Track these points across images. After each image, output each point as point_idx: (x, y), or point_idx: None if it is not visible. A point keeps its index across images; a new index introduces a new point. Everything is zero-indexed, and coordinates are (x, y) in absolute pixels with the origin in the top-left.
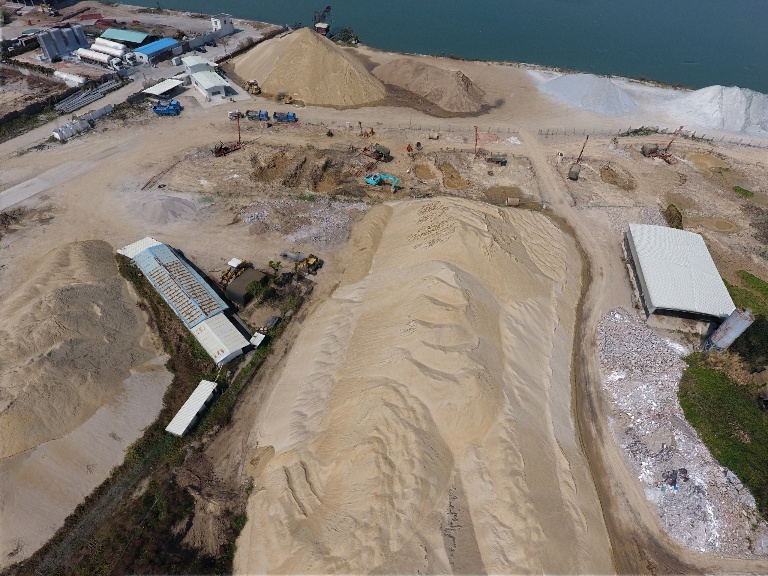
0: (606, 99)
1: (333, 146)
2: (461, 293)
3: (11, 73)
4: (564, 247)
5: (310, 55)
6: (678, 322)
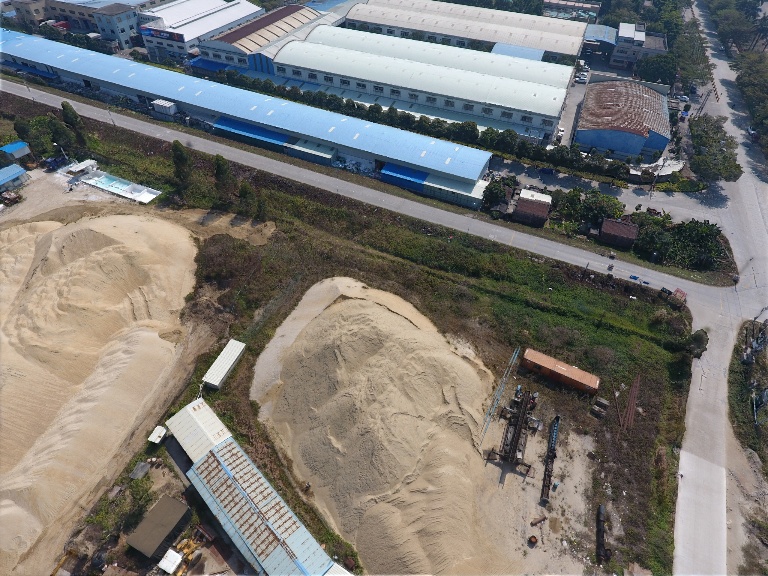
0: None
1: None
2: None
3: None
4: None
5: None
6: None
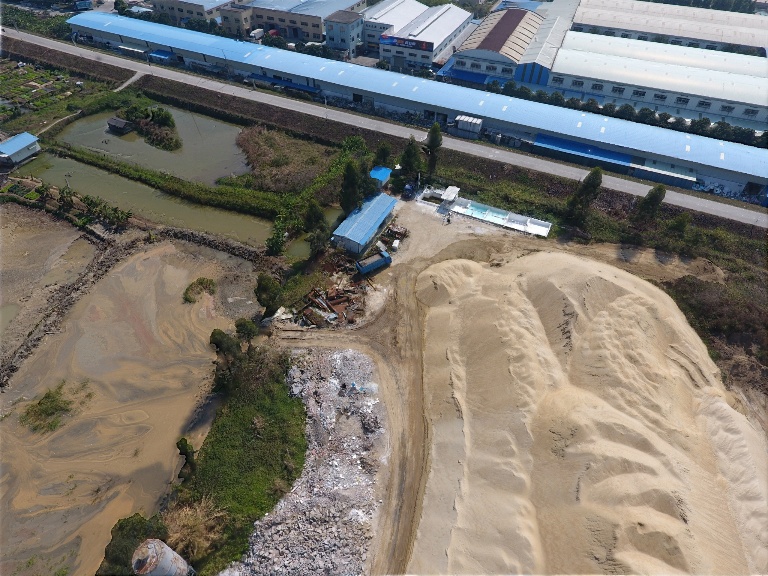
0: None
1: None
2: (634, 569)
3: None
4: None
5: None
6: None
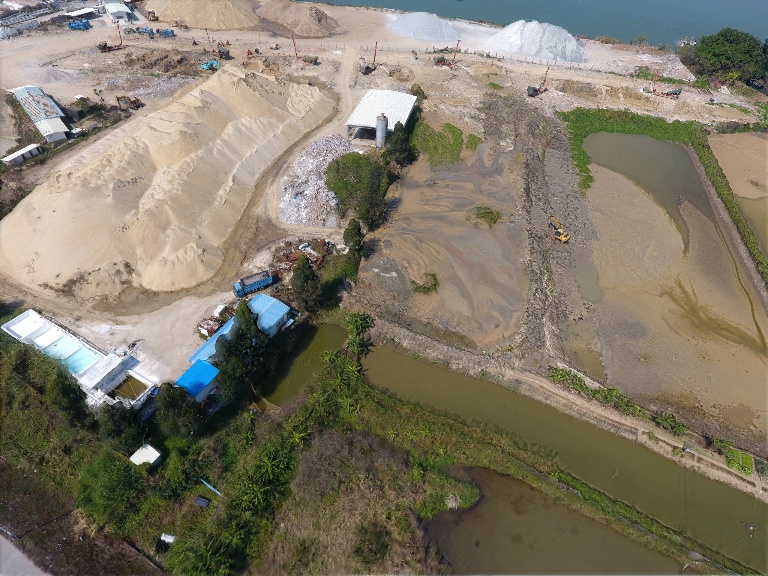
0: (431, 30)
1: (193, 50)
2: (199, 100)
3: None
4: (316, 101)
5: None
6: (373, 142)
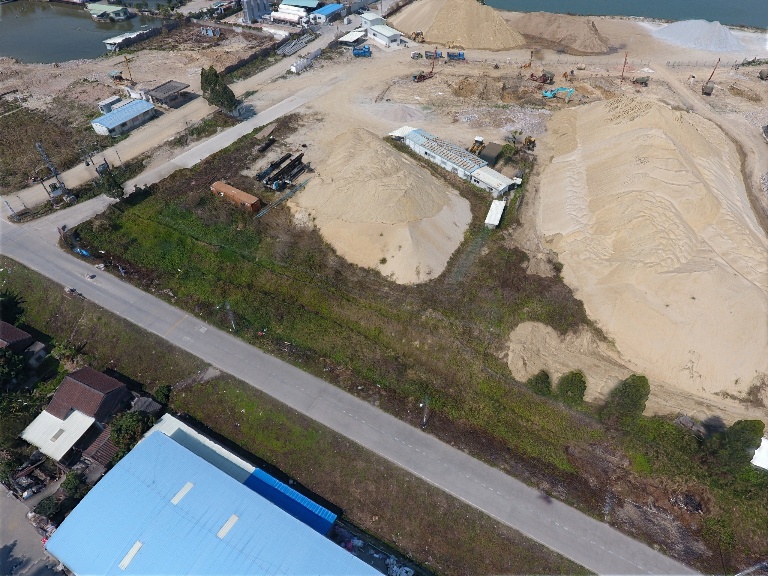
0: (717, 39)
1: (503, 75)
2: (672, 142)
3: (227, 31)
4: (721, 132)
5: (465, 9)
6: None
